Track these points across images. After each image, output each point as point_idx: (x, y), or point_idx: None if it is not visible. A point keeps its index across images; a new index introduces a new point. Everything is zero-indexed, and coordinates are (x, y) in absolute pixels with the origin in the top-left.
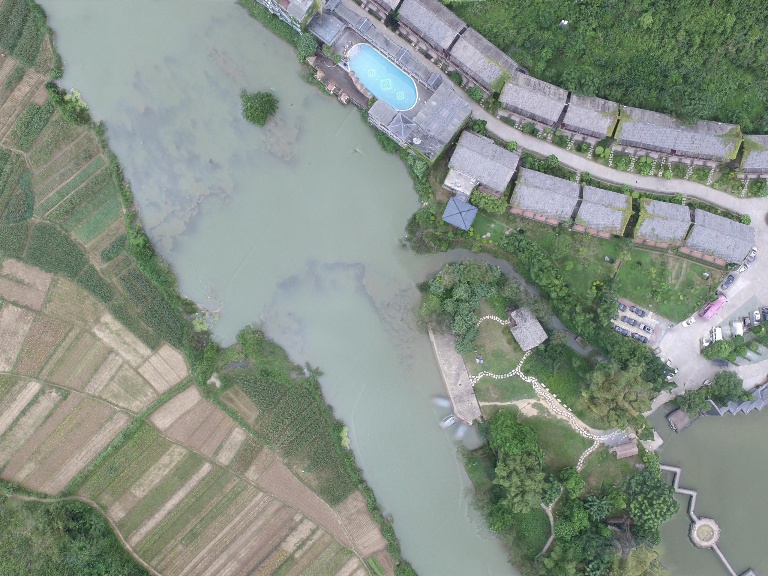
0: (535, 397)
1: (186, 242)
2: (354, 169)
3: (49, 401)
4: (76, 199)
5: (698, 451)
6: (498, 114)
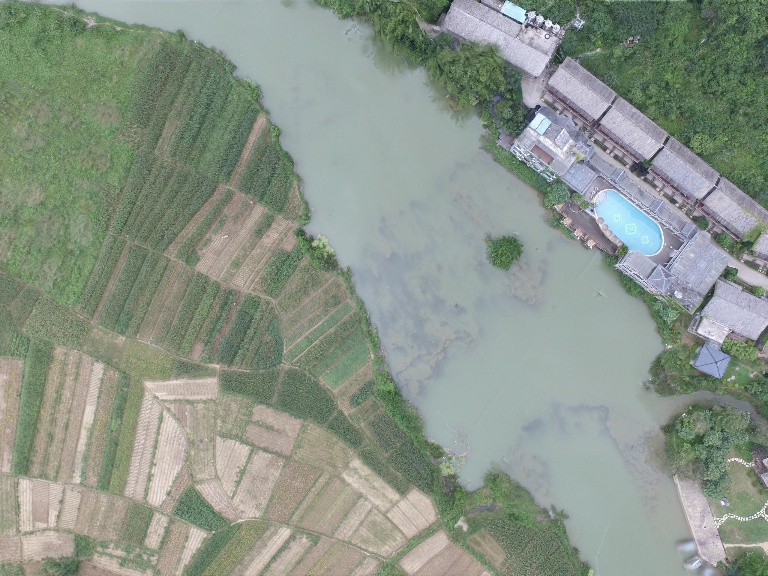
0: None
1: (432, 386)
2: (598, 312)
3: (300, 547)
4: (325, 345)
5: None
6: (743, 258)
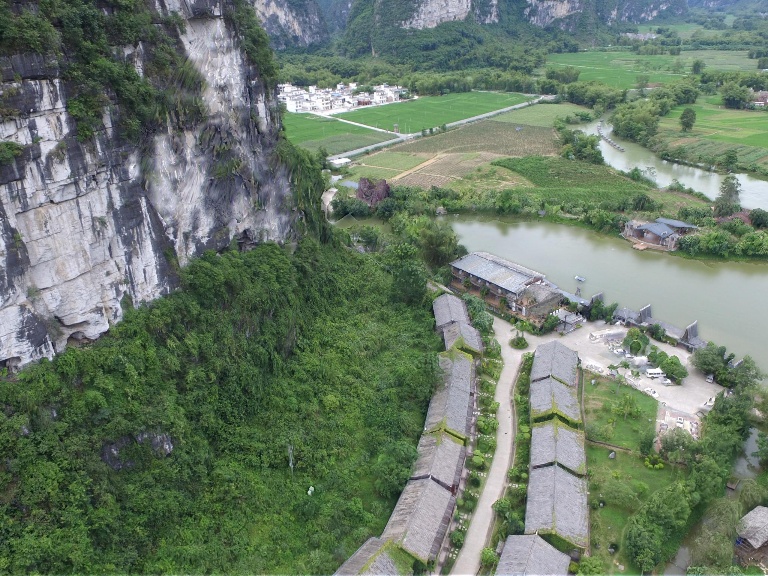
0: None
1: None
2: None
3: None
4: None
5: None
6: None
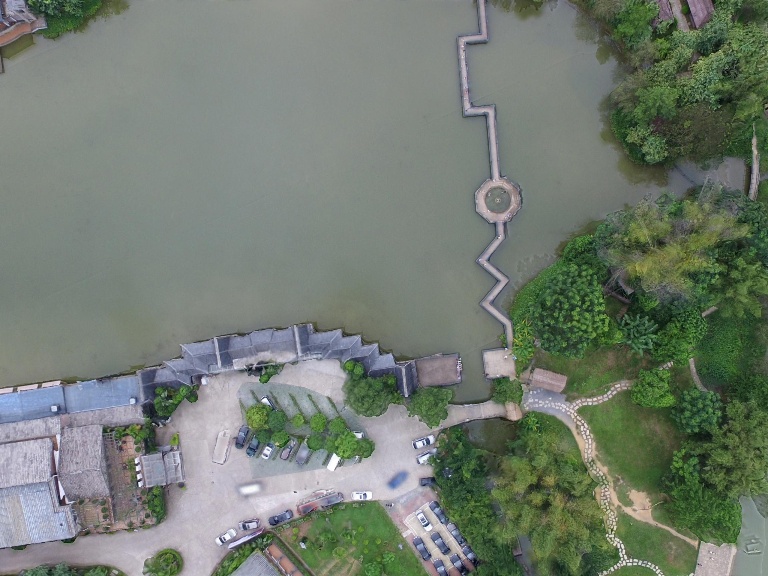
0: (622, 514)
1: None
2: None
3: None
4: None
5: (445, 313)
6: None
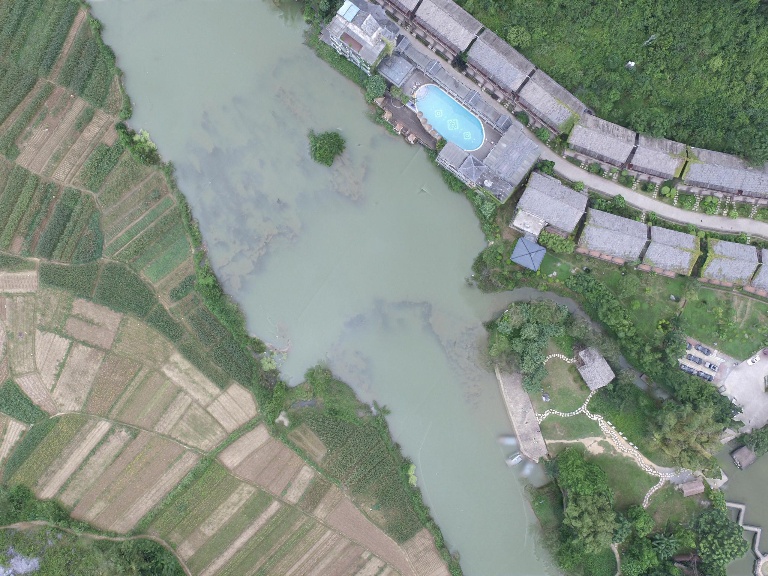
0: (601, 435)
1: (254, 281)
2: (421, 208)
3: (119, 440)
4: (145, 239)
5: (762, 488)
6: (564, 154)
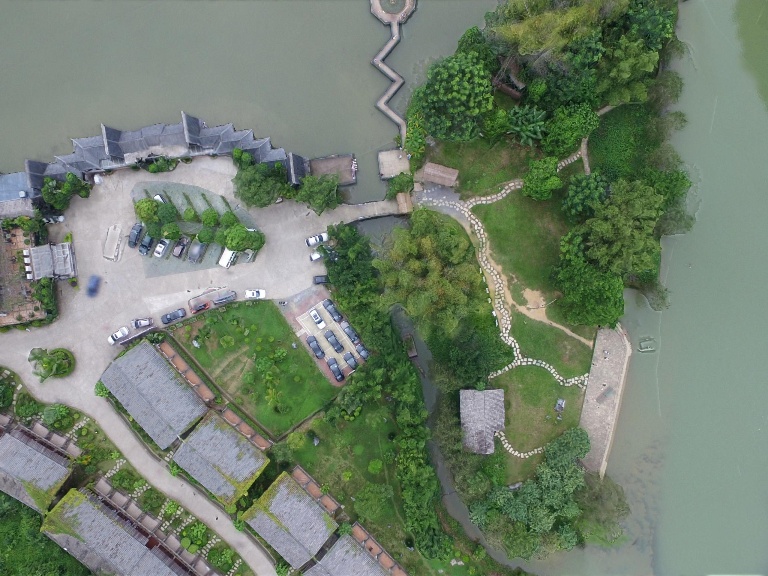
0: (517, 313)
1: None
2: None
3: None
4: None
5: (340, 114)
6: None
